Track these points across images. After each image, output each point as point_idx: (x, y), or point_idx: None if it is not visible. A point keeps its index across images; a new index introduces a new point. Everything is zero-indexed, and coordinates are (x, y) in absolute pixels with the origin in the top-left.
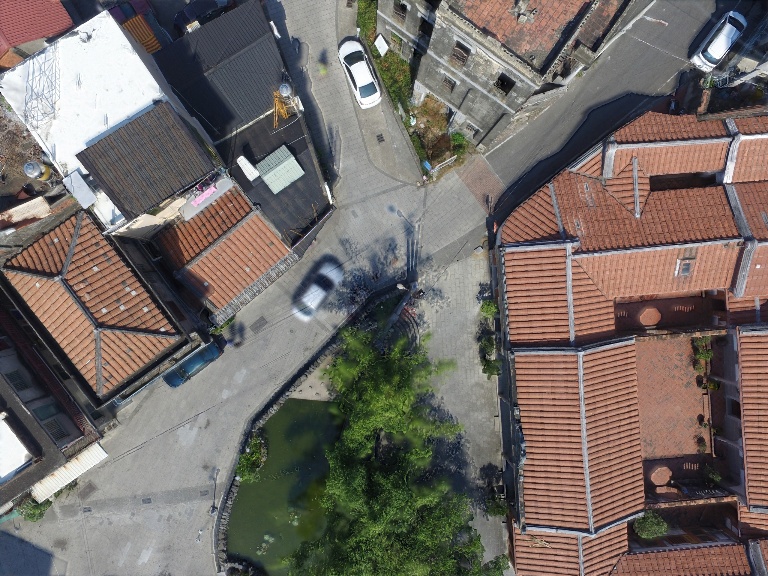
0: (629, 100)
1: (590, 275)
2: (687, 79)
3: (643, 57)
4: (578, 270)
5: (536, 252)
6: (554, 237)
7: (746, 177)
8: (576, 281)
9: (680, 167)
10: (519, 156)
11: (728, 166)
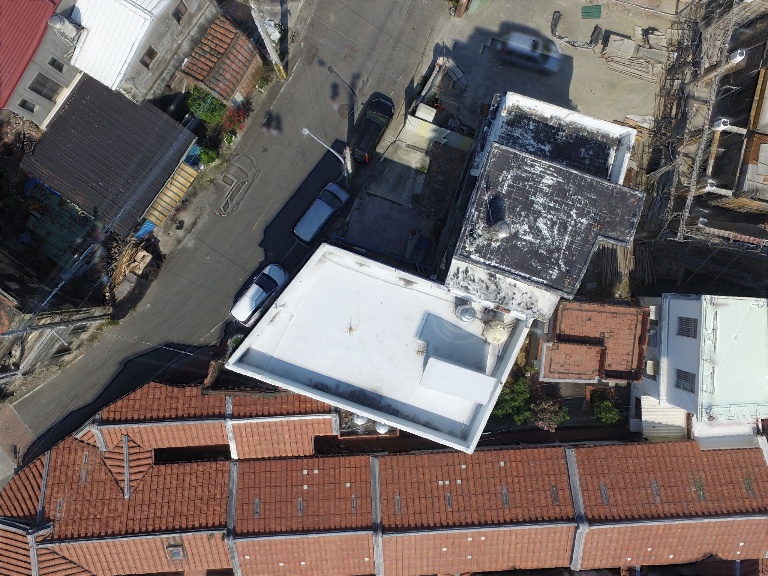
0: (169, 350)
1: (70, 559)
2: (233, 329)
3: (185, 306)
4: (50, 557)
5: (12, 533)
6: (32, 518)
7: (253, 454)
8: (47, 569)
9: (181, 442)
10: (49, 406)
11: (230, 444)
